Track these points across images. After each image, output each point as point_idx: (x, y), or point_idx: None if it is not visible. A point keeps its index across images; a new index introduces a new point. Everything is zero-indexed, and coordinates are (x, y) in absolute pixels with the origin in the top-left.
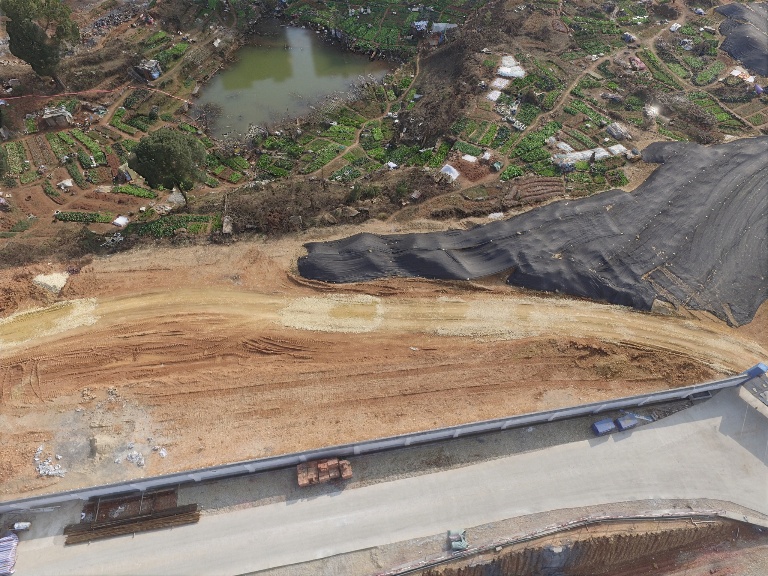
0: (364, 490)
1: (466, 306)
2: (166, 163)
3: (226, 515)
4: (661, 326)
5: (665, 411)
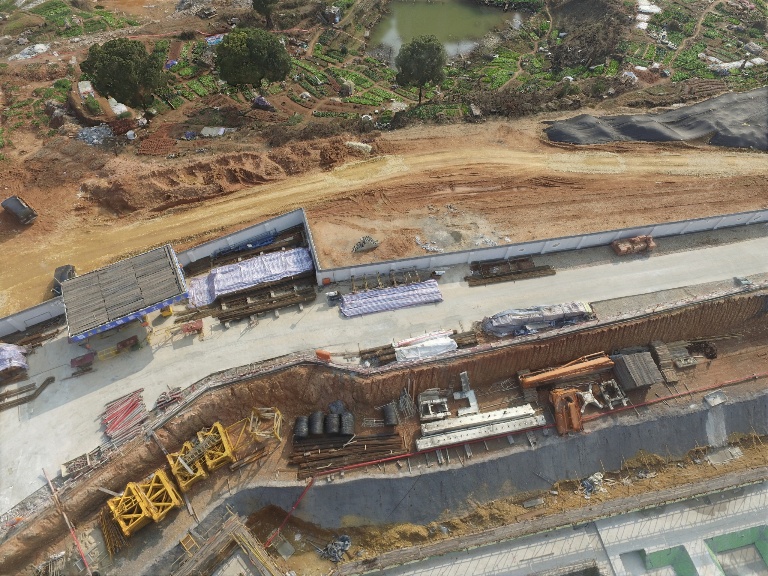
0: (664, 257)
1: (685, 158)
2: (430, 60)
3: (573, 270)
4: None
5: None
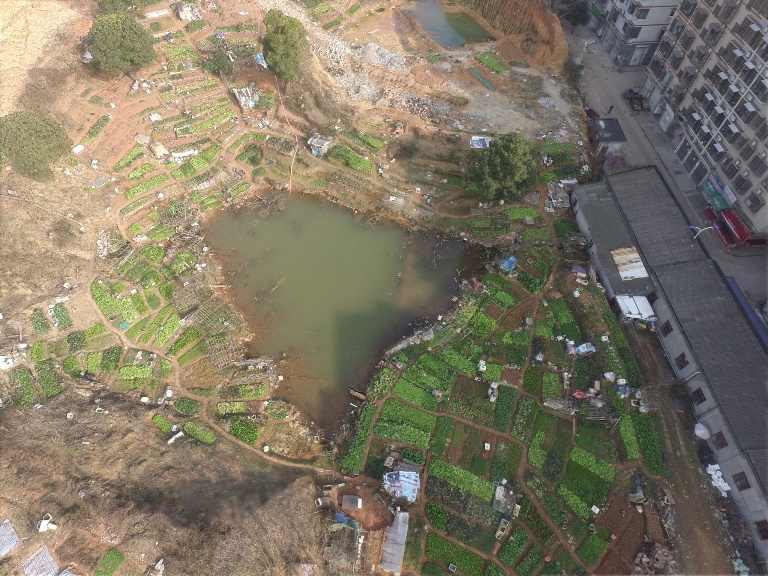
0: None
1: None
2: None
3: None
4: None
5: None
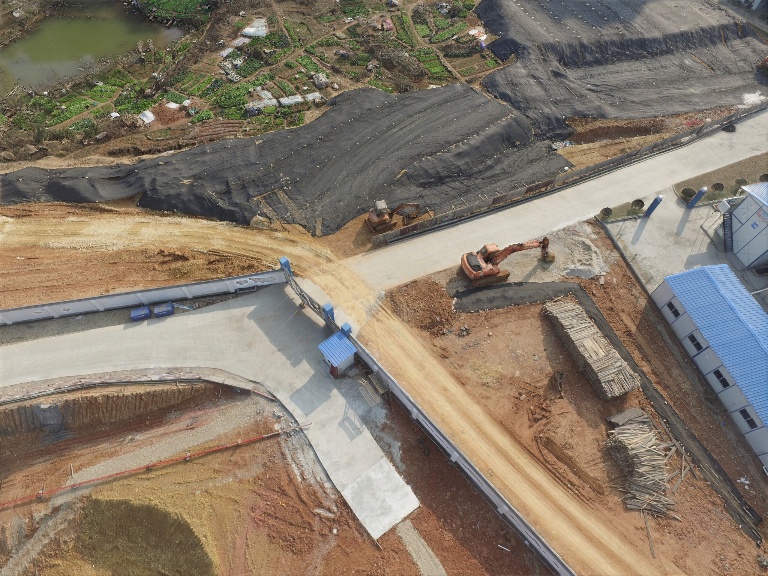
0: None
1: (88, 224)
2: None
3: None
4: (253, 238)
5: (208, 302)
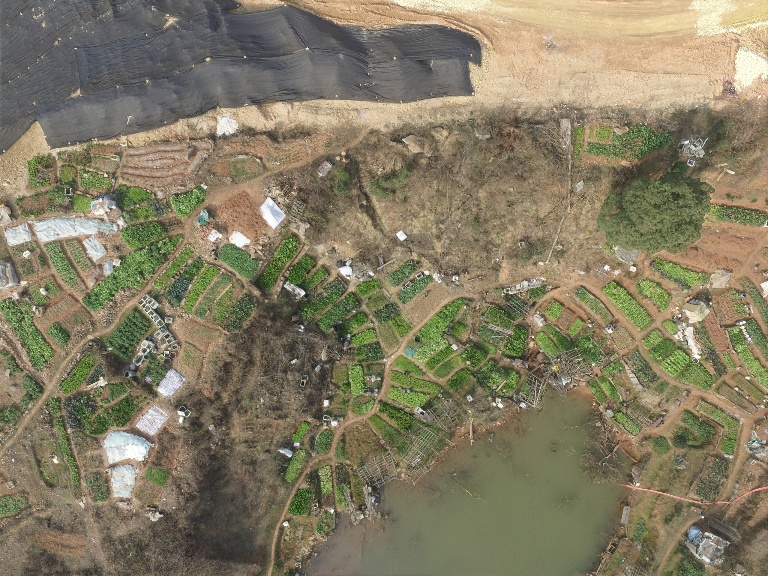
0: None
1: None
2: None
3: None
4: None
5: None
